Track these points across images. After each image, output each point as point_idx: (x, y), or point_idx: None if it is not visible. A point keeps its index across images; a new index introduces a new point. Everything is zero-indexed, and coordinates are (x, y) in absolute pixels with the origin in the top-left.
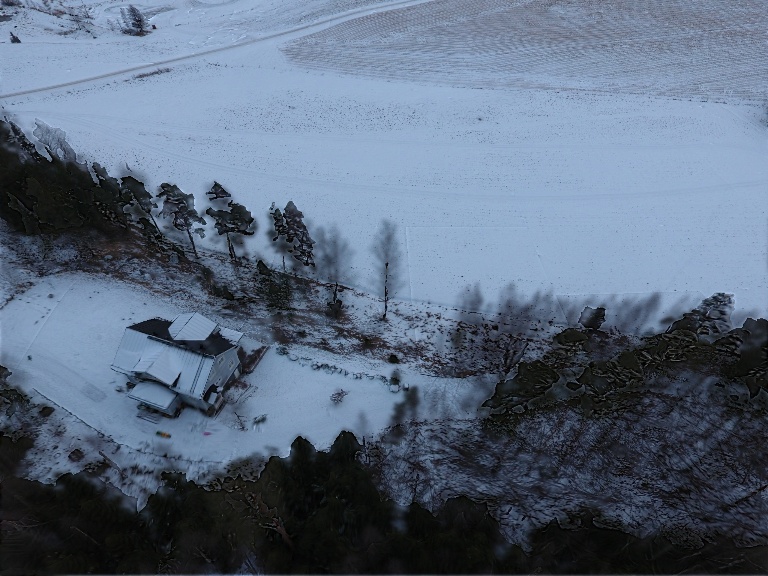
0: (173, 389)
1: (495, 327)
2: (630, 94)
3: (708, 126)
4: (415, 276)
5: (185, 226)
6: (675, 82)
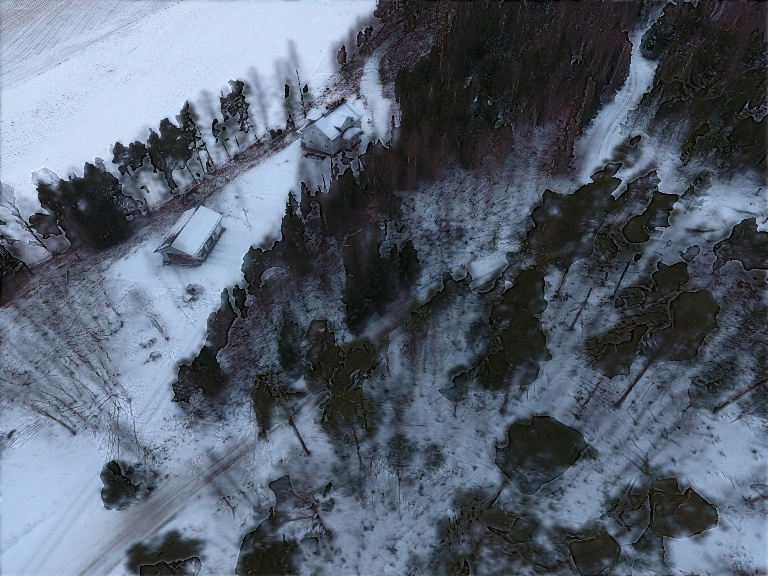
0: (354, 122)
1: (327, 89)
2: (142, 18)
3: (207, 8)
4: (274, 109)
5: (194, 148)
6: (145, 3)
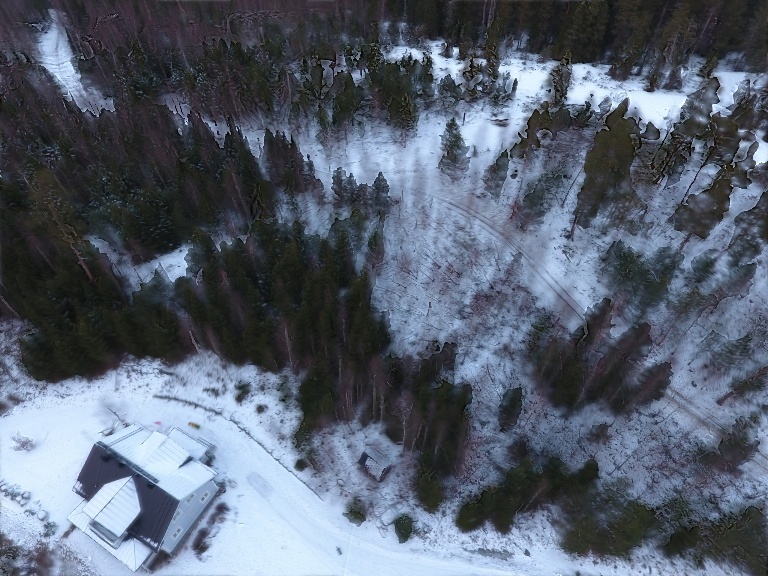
0: None
1: None
2: None
3: None
4: None
5: None
6: None
